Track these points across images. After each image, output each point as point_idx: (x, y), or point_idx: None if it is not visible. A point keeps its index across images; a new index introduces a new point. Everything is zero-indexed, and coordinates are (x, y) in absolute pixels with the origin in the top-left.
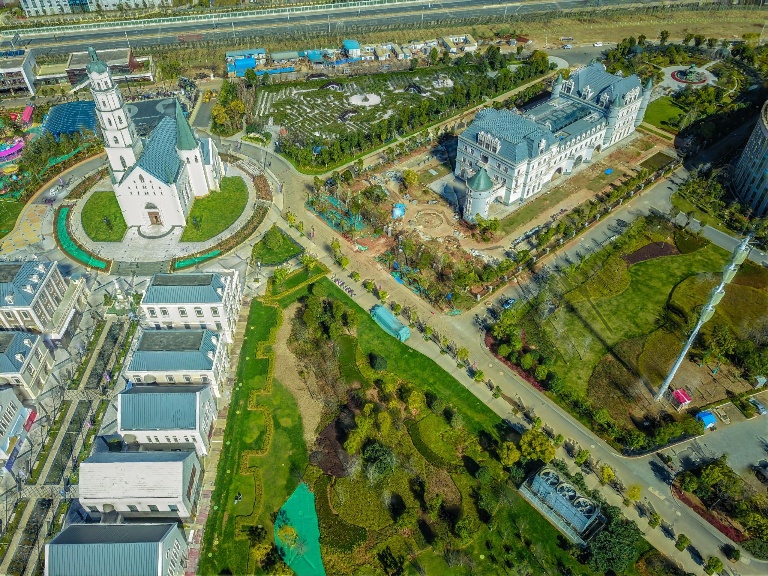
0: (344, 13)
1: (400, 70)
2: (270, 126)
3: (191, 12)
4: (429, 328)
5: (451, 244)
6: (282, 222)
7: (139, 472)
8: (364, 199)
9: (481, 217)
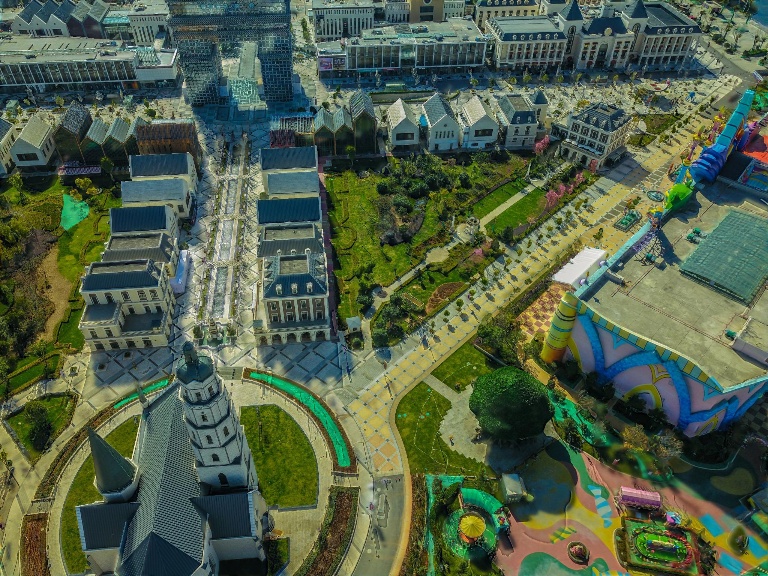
0: None
1: None
2: None
3: None
4: None
5: None
6: (21, 472)
7: None
8: None
9: None
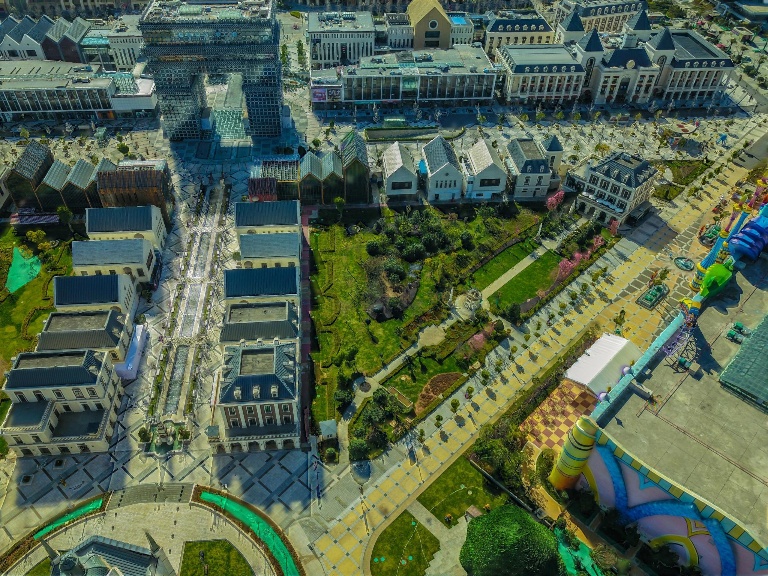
0: None
1: None
2: None
3: None
4: None
5: None
6: None
7: None
8: None
9: None
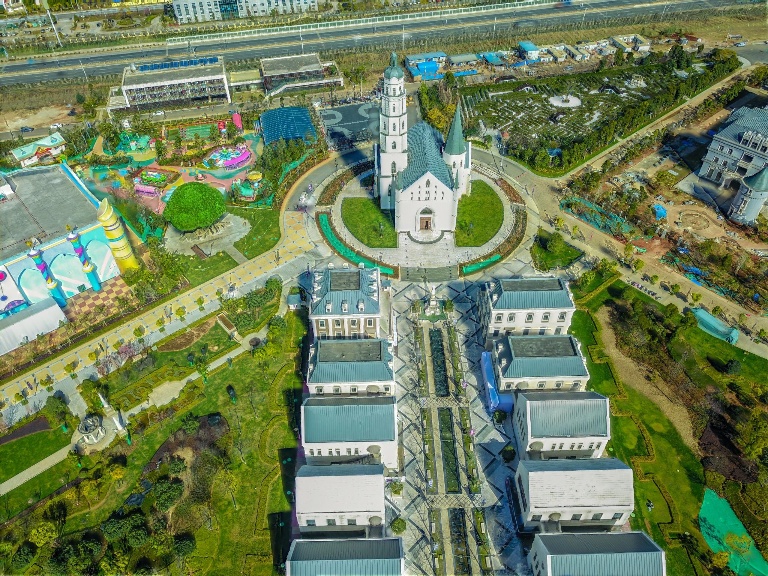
0: (496, 15)
1: (585, 71)
2: (483, 129)
3: (340, 17)
4: (763, 330)
5: (730, 245)
6: (546, 225)
7: (589, 480)
8: (617, 201)
9: (763, 217)
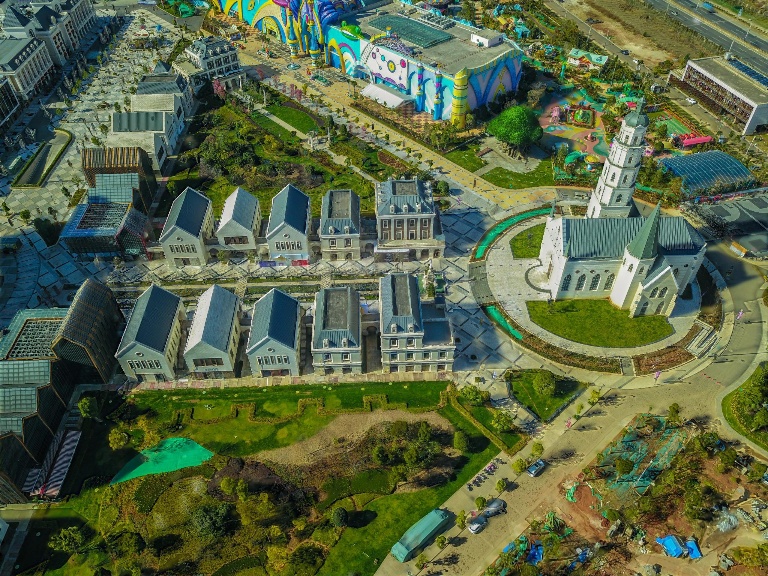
0: None
1: None
2: None
3: None
4: None
5: None
6: None
7: None
8: None
9: None
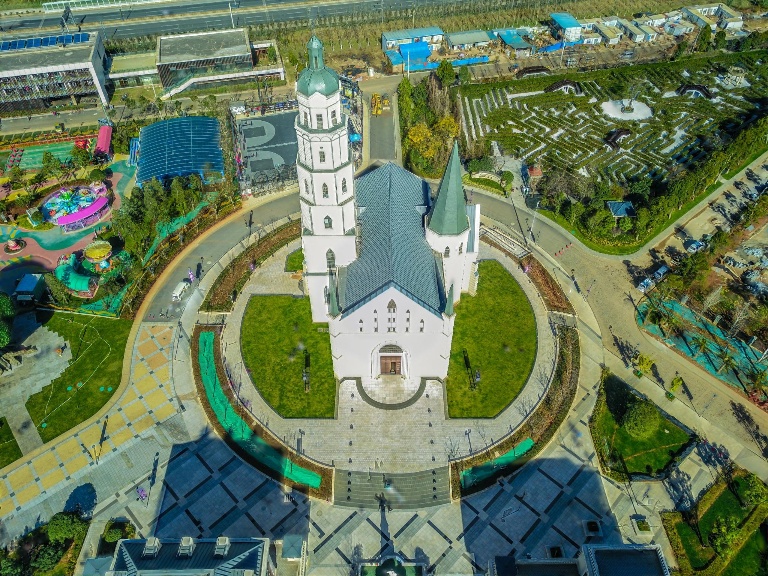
0: None
1: (652, 59)
2: (497, 157)
3: None
4: None
5: None
6: (615, 363)
7: None
8: None
9: None
